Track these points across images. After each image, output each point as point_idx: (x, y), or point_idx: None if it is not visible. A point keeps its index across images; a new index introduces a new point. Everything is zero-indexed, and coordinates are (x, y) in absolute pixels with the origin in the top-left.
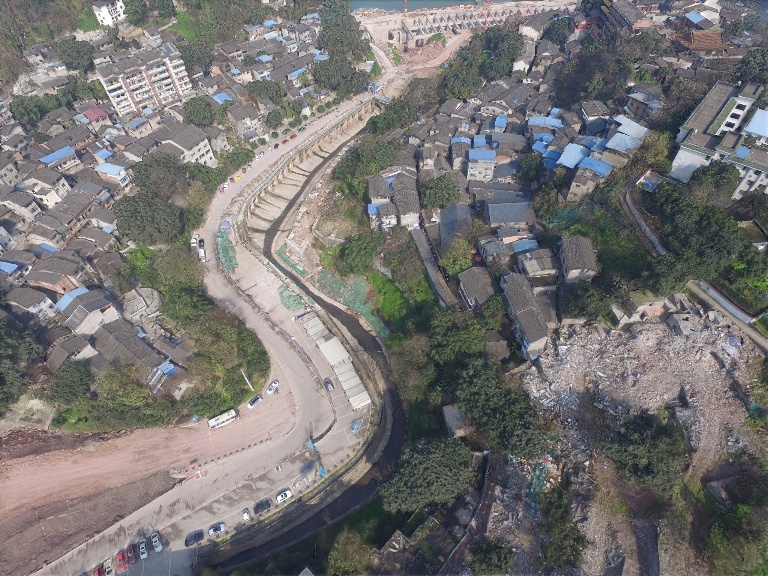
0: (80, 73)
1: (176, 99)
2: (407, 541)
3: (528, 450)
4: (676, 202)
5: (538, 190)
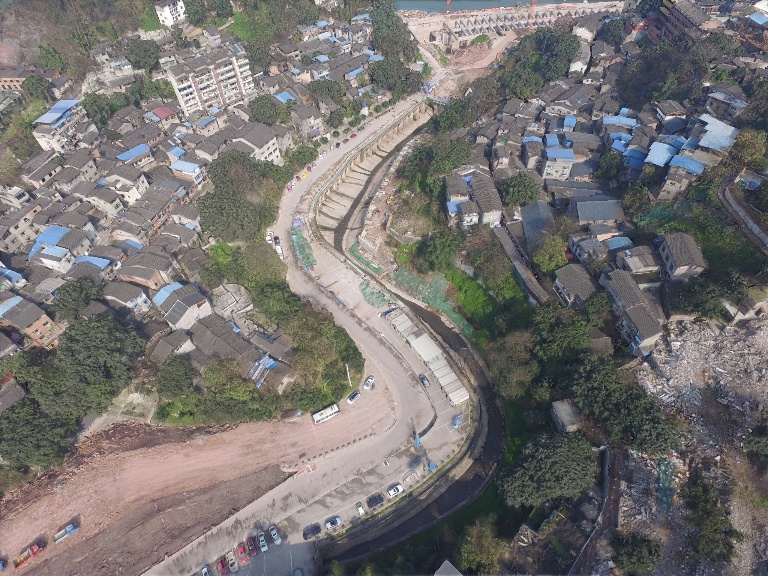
0: (146, 72)
1: (239, 98)
2: (535, 535)
3: (658, 445)
4: None
5: (618, 189)
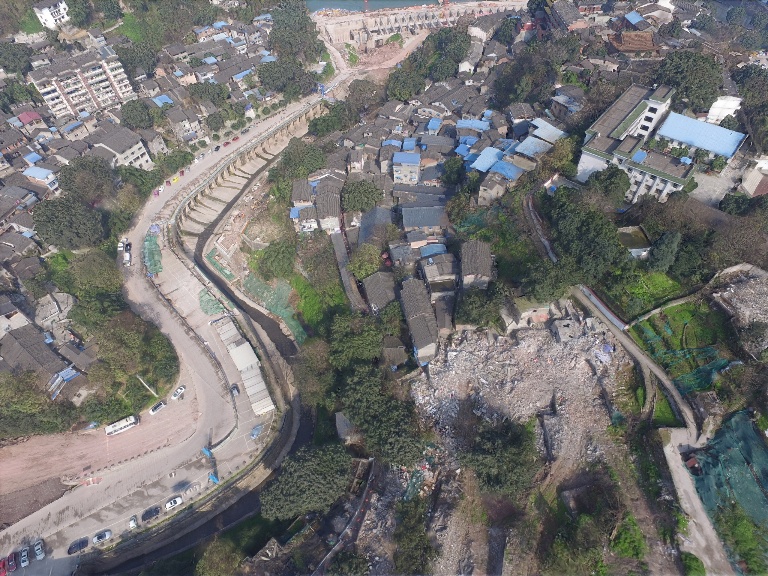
0: (18, 76)
1: (116, 102)
2: (281, 549)
3: (400, 458)
4: (562, 208)
5: None
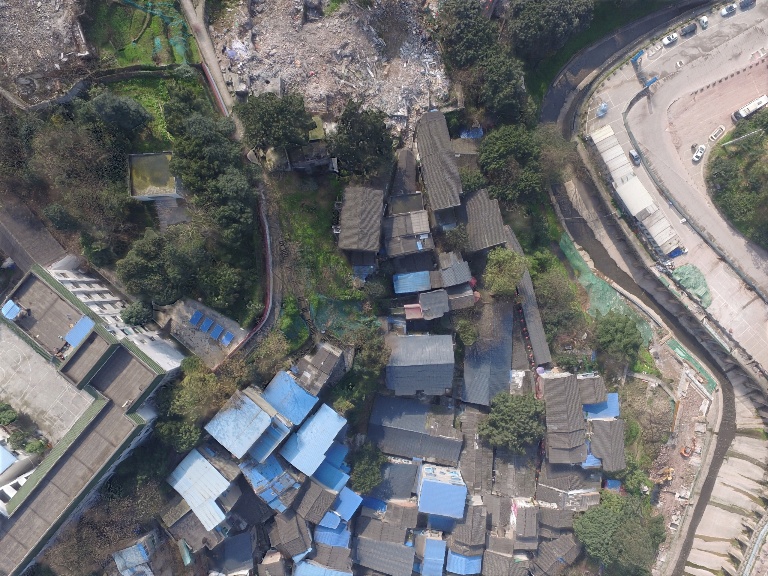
0: None
1: None
2: None
3: None
4: None
5: (359, 425)
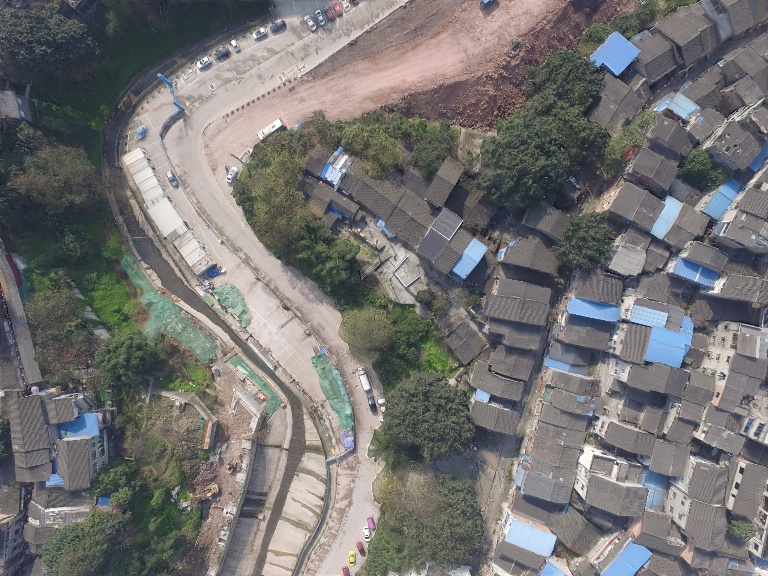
0: None
1: None
2: None
3: None
4: None
5: None
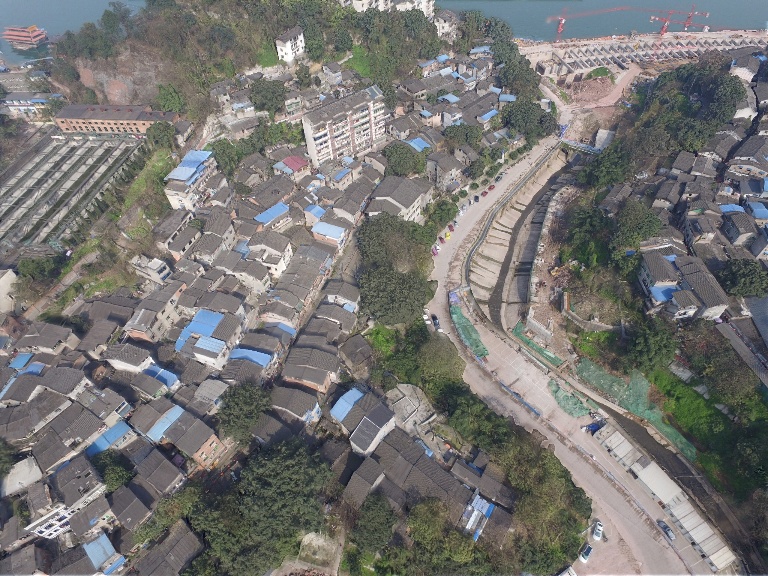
0: (271, 115)
1: (369, 144)
2: None
3: None
4: None
5: None
